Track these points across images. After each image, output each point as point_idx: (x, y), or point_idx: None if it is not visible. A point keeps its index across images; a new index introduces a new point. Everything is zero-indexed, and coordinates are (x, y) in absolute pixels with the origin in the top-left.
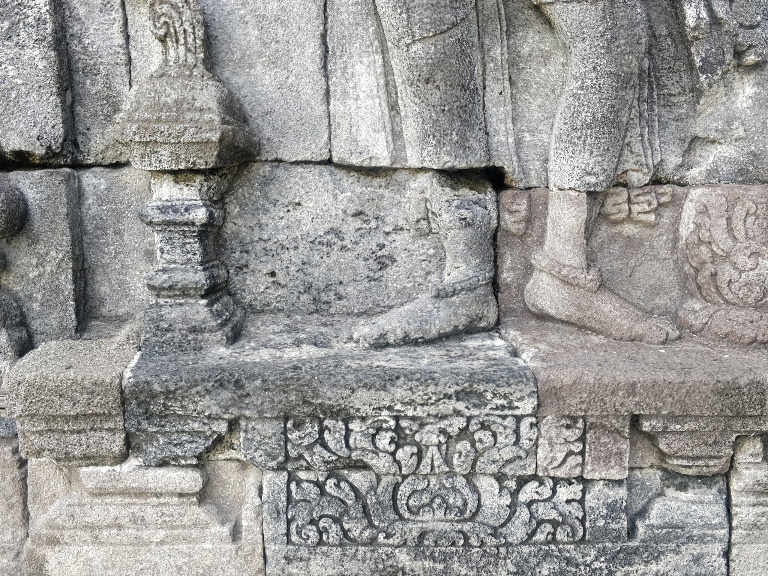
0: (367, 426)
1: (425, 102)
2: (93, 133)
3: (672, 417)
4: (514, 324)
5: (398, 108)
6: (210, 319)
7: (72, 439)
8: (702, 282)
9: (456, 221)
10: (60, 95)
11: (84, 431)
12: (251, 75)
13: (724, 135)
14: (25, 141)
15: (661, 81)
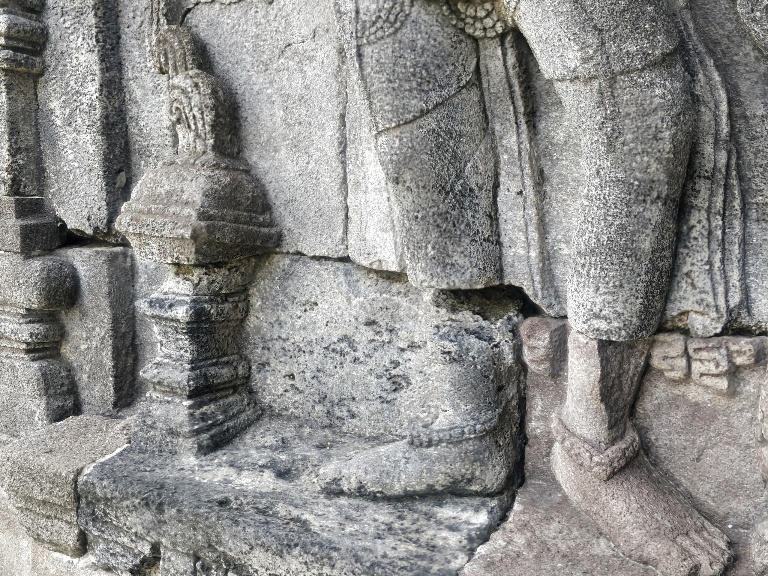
0: None
1: (400, 205)
2: None
3: None
4: (533, 492)
5: None
6: (186, 423)
7: (42, 523)
8: None
9: (438, 354)
10: (106, 178)
11: (51, 517)
12: (276, 159)
13: None
14: (79, 221)
15: (754, 183)
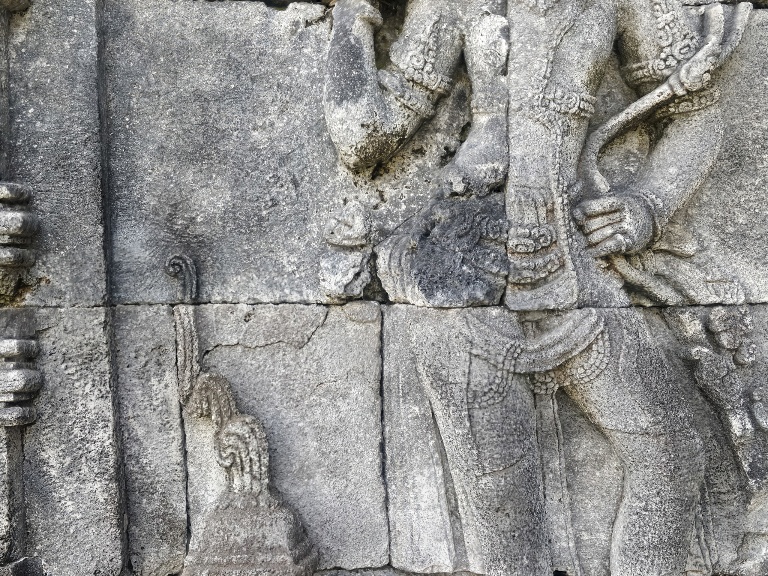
0: None
1: (494, 527)
2: (147, 552)
3: None
4: None
5: (458, 513)
6: None
7: None
8: None
9: None
10: (119, 526)
11: None
12: (310, 485)
13: None
14: None
15: (710, 480)
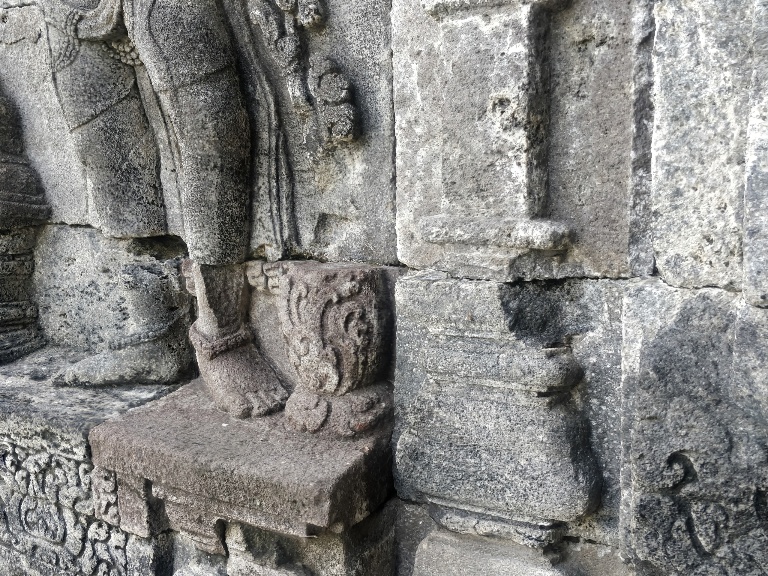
0: None
1: None
2: None
3: (171, 488)
4: (198, 381)
5: None
6: None
7: None
8: (289, 362)
9: (122, 284)
10: None
11: None
12: (45, 155)
13: (346, 212)
14: None
15: (295, 157)
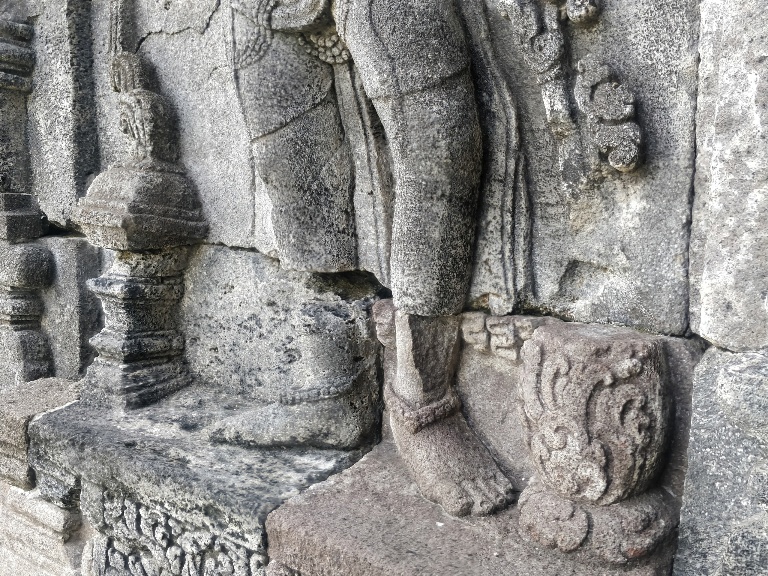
0: (149, 515)
1: None
2: None
3: None
4: (383, 448)
5: None
6: (119, 383)
7: (3, 461)
8: None
9: (301, 327)
10: (77, 179)
11: (10, 456)
12: (205, 164)
13: (608, 261)
14: (56, 214)
15: (538, 186)
